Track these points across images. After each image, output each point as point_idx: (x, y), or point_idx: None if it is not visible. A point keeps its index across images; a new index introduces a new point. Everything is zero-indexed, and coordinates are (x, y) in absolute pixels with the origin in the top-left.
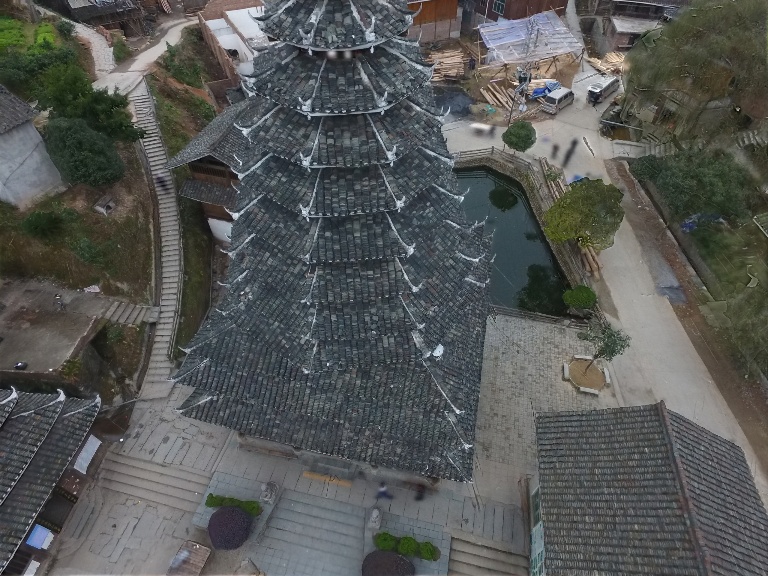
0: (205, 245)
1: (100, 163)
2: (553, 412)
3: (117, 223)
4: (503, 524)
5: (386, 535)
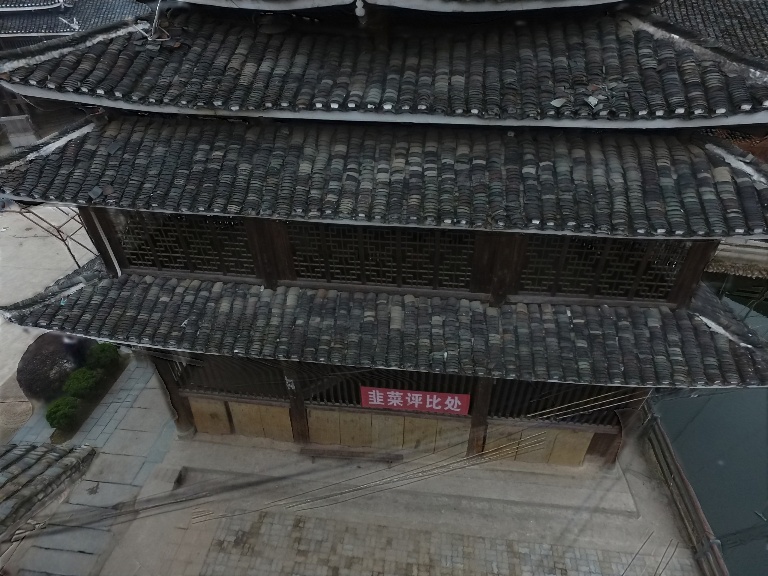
0: None
1: None
2: (41, 482)
3: None
4: (51, 573)
5: (110, 352)
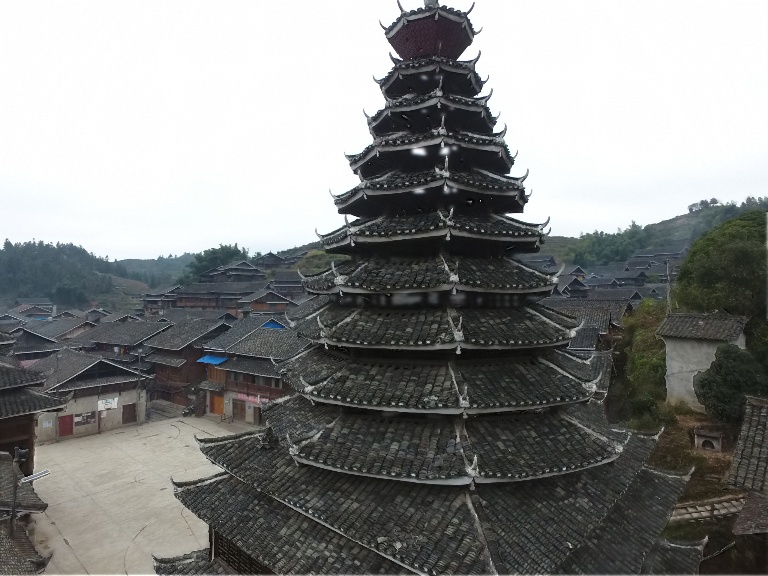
0: (737, 560)
1: (720, 392)
2: None
3: (682, 448)
4: None
5: None
